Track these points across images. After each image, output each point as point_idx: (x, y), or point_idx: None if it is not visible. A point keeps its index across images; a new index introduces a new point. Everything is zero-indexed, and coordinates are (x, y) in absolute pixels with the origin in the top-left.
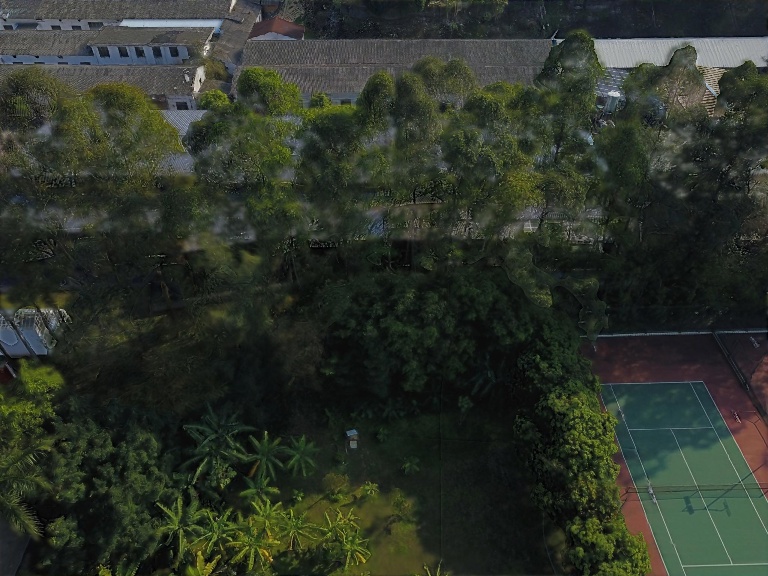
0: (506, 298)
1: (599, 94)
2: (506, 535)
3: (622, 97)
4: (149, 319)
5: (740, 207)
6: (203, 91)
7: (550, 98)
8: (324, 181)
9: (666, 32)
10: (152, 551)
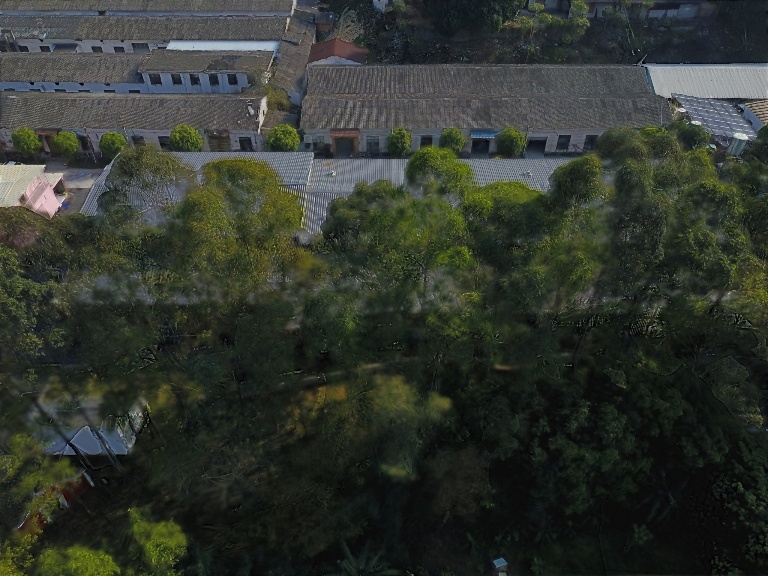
0: (692, 408)
1: (709, 131)
2: None
3: None
4: None
5: None
6: (267, 124)
7: (765, 176)
8: (512, 289)
9: (759, 56)
10: None
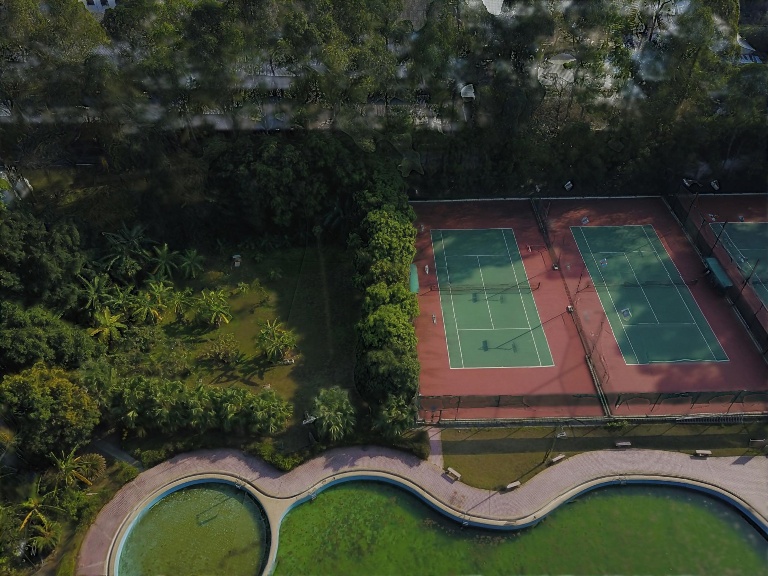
0: (348, 152)
1: None
2: (336, 314)
3: None
4: (93, 188)
5: (530, 88)
6: None
7: None
8: (197, 48)
9: None
10: (74, 305)
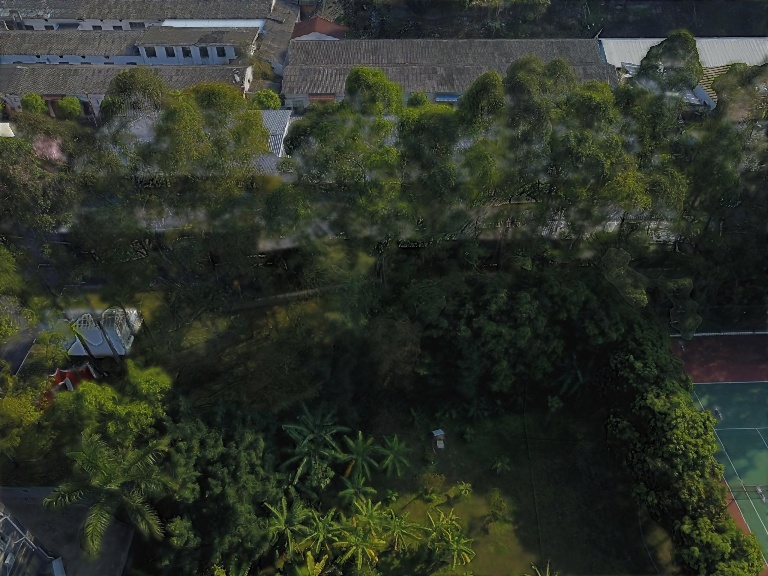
0: (595, 298)
1: None
2: (604, 535)
3: None
4: None
5: None
6: (252, 91)
7: (647, 98)
8: (431, 181)
9: (707, 32)
10: (262, 551)
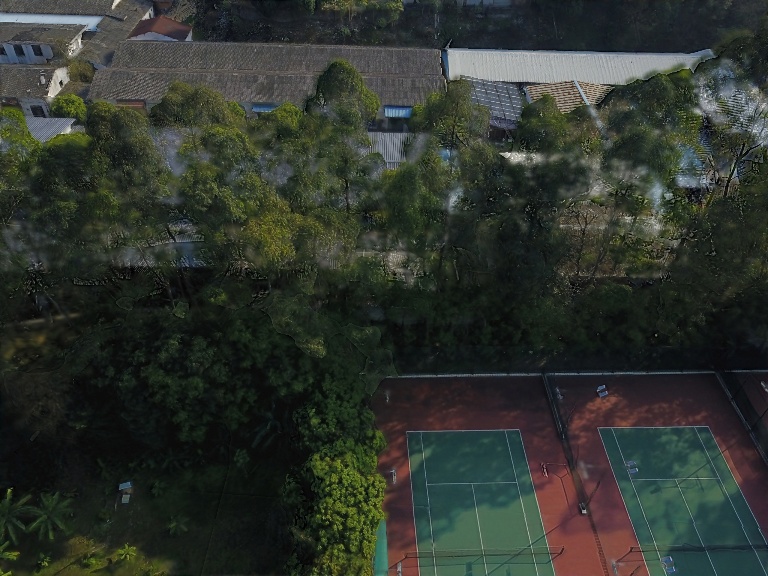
0: (289, 344)
1: None
2: None
3: (501, 114)
4: None
5: (550, 248)
6: (63, 94)
7: (323, 130)
8: (42, 221)
9: (568, 45)
10: None
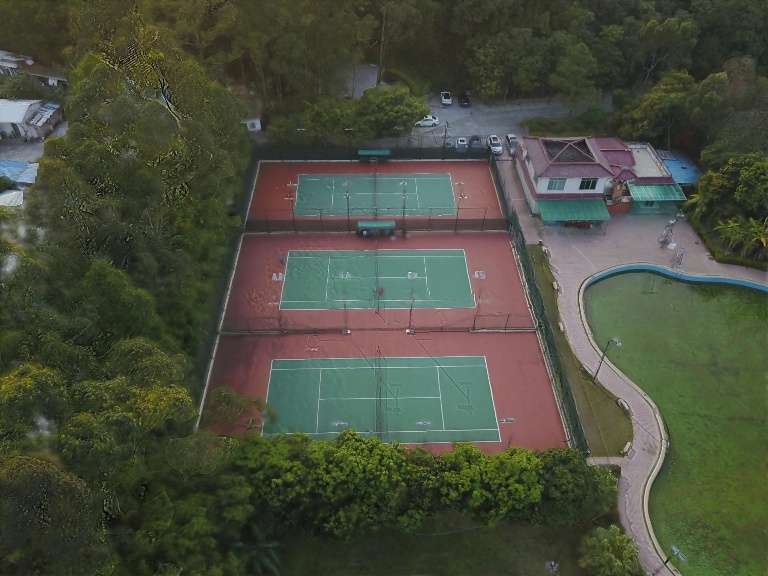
0: (195, 494)
1: None
2: (424, 572)
3: None
4: None
5: (159, 244)
6: None
7: (0, 320)
8: None
9: None
10: None
